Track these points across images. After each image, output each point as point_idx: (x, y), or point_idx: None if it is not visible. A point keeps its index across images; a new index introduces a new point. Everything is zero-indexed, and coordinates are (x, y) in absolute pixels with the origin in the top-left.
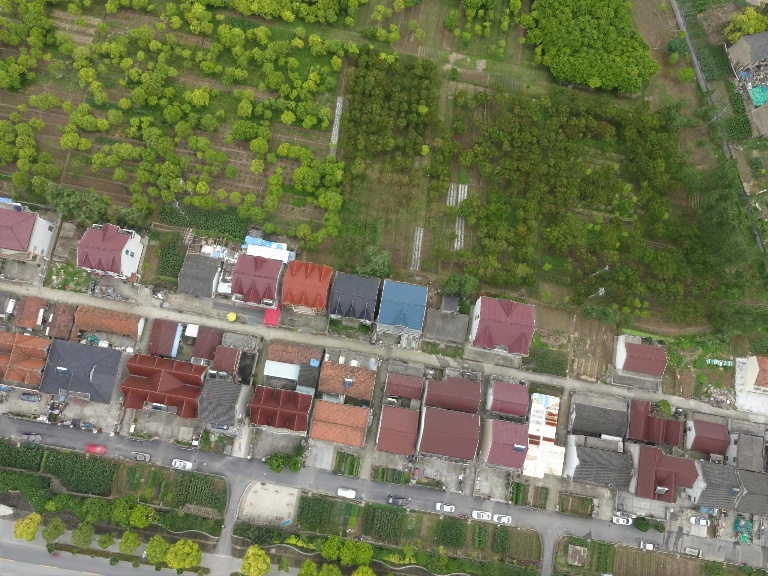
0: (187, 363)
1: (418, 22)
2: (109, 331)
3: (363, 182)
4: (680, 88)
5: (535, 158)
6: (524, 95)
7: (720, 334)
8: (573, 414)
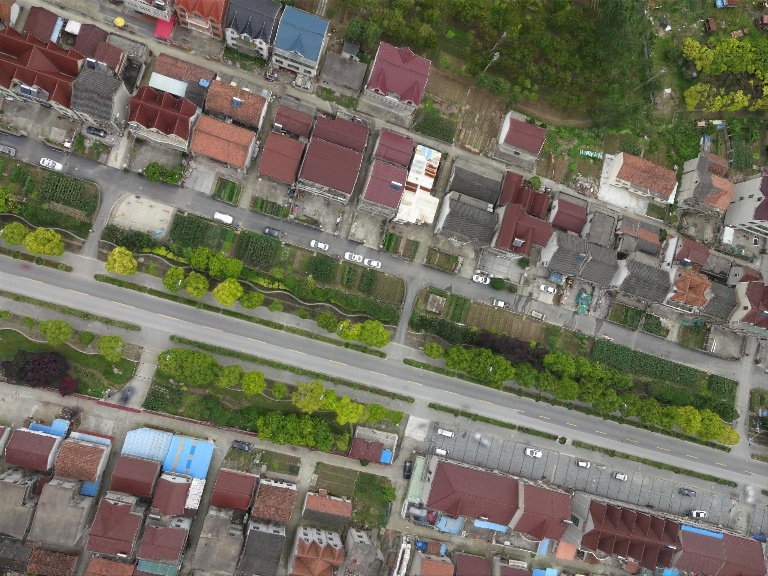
0: (63, 50)
1: None
2: None
3: None
4: None
5: None
6: None
7: (596, 128)
8: (452, 176)
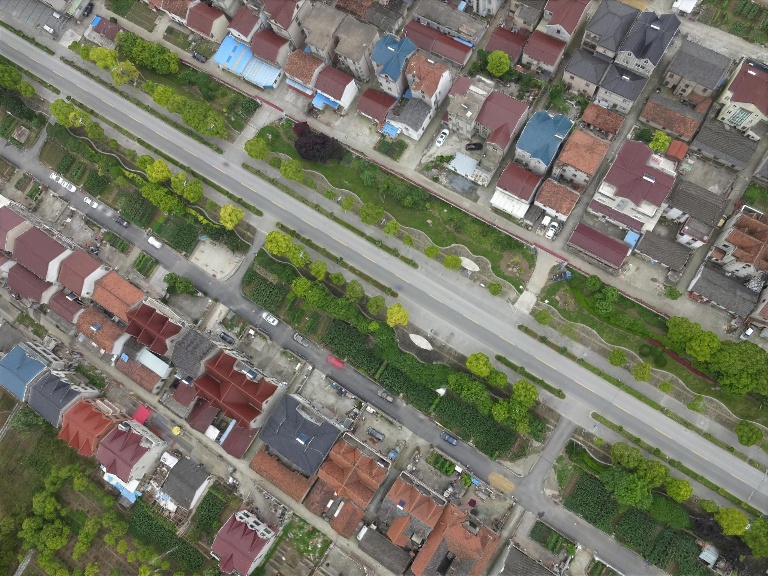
0: (209, 401)
1: None
2: (283, 466)
3: None
4: None
5: None
6: None
7: None
8: None
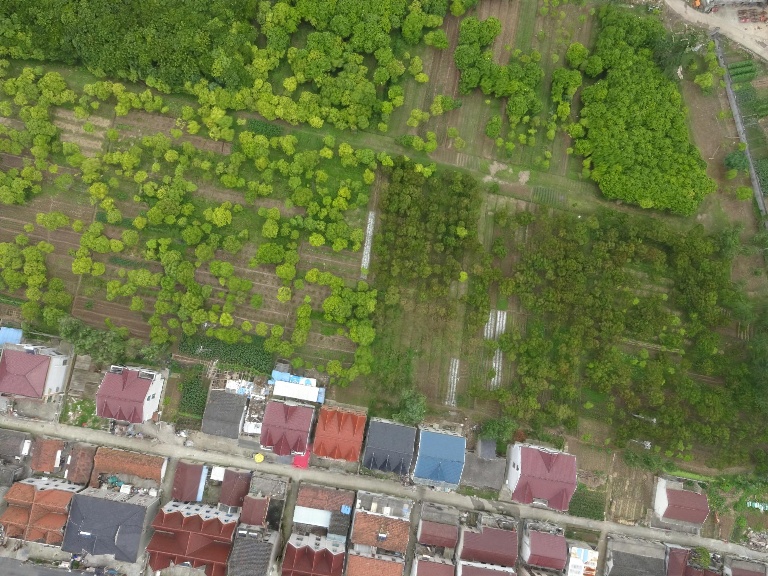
0: (215, 519)
1: (457, 126)
2: (131, 474)
3: (396, 309)
4: (735, 204)
5: (580, 288)
6: (569, 210)
7: (763, 477)
8: (610, 562)
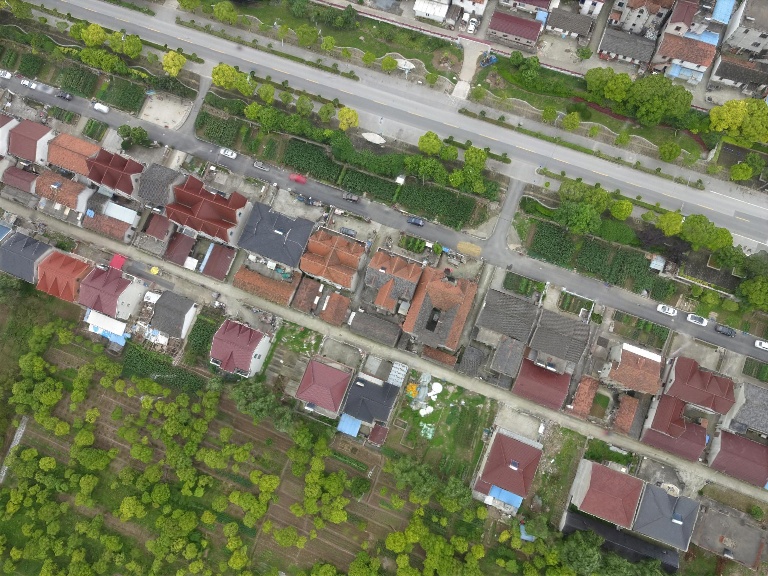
0: None
1: None
2: (266, 277)
3: None
4: None
5: None
6: None
7: None
8: None
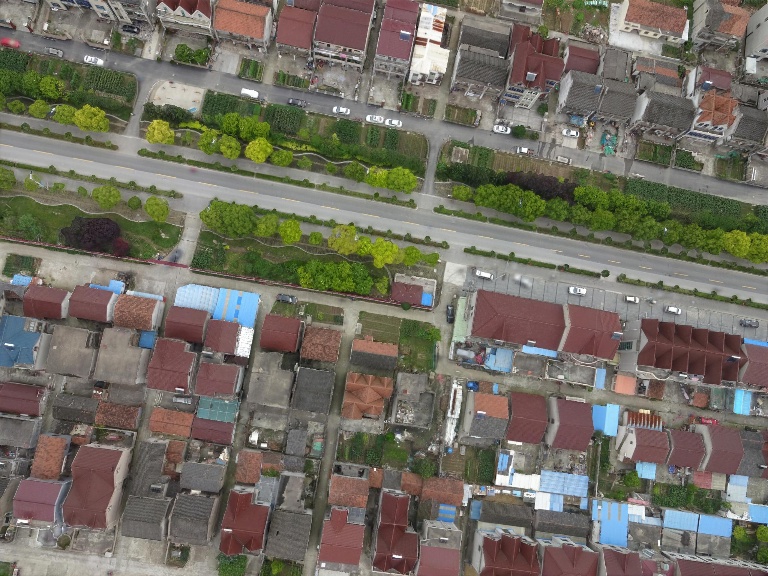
0: None
1: None
2: None
3: None
4: None
5: None
6: None
7: None
8: None
